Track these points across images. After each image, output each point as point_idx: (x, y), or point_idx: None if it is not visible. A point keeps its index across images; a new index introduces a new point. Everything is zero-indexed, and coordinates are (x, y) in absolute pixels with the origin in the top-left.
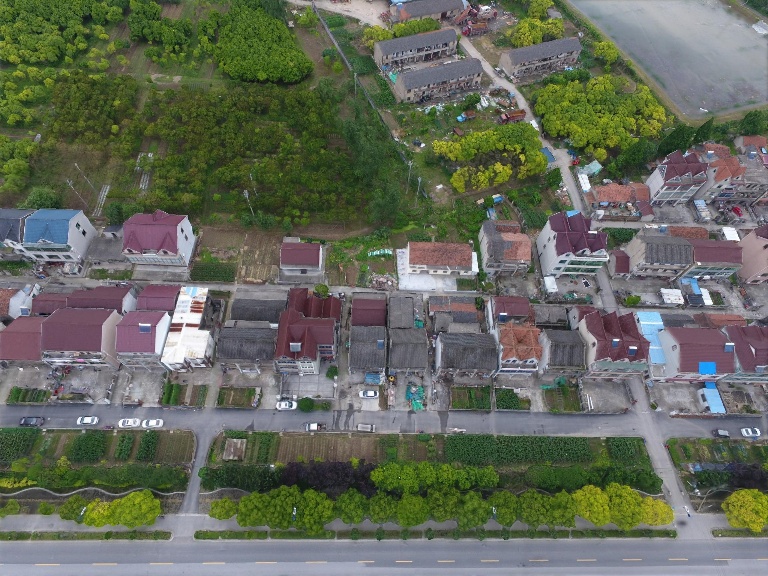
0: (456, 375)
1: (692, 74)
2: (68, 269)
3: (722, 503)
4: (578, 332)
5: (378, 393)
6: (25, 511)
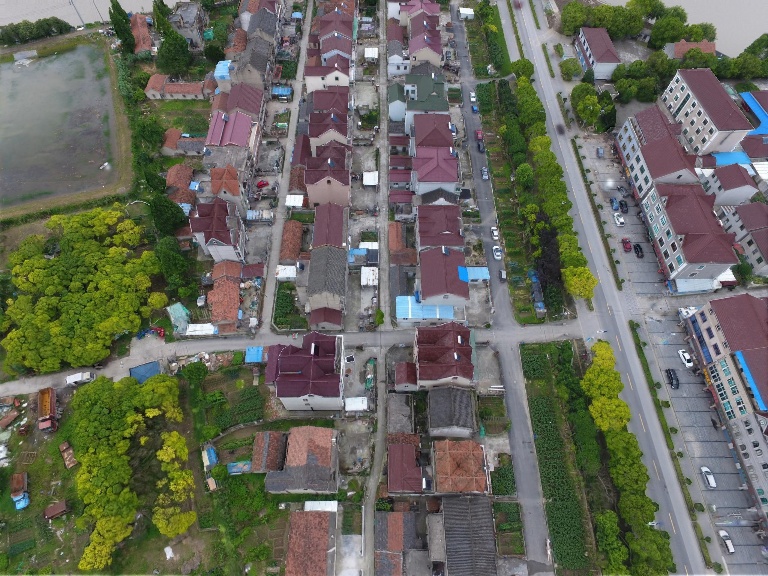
0: None
1: (37, 158)
2: None
3: (576, 298)
4: (432, 389)
5: None
6: None
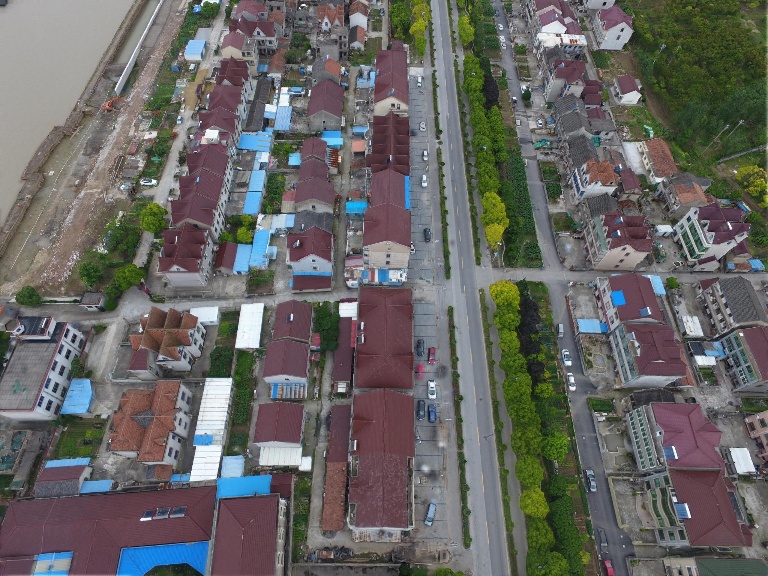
0: (564, 166)
1: None
2: (580, 7)
3: None
4: None
5: (541, 125)
6: None
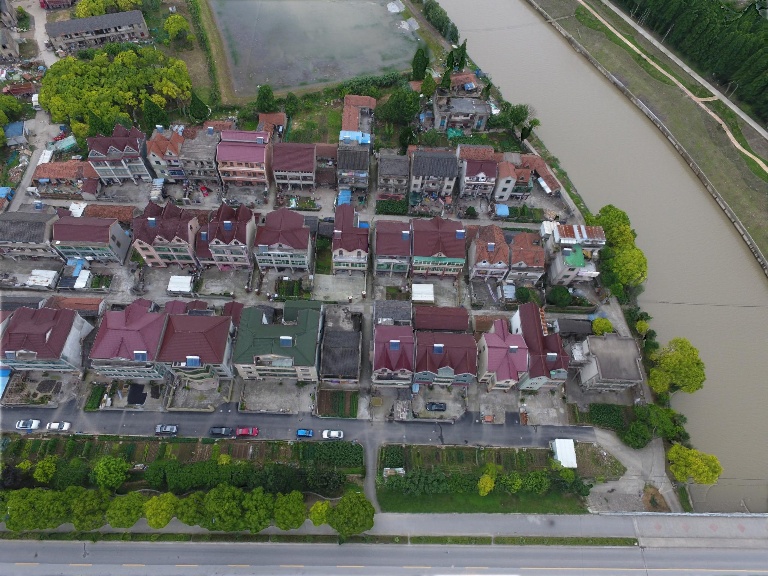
0: None
1: (278, 51)
2: None
3: None
4: None
5: None
6: None
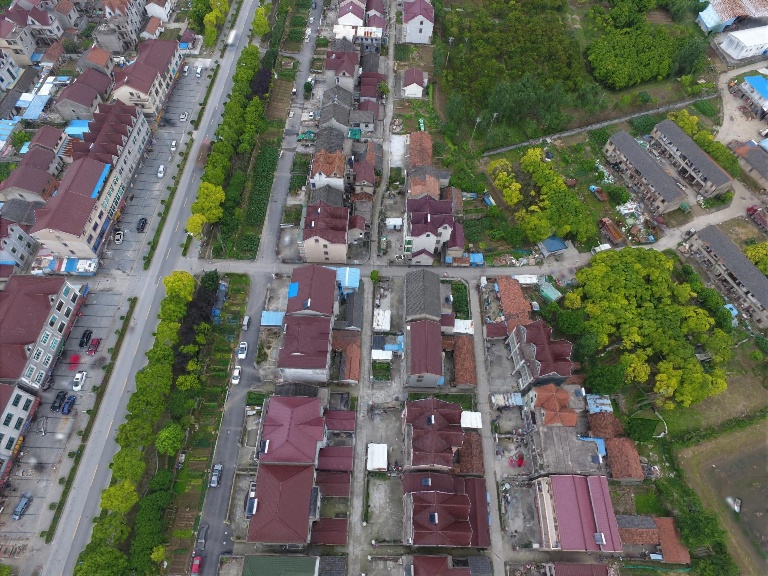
0: None
1: None
2: (400, 1)
3: None
4: None
5: (311, 117)
6: (271, 7)
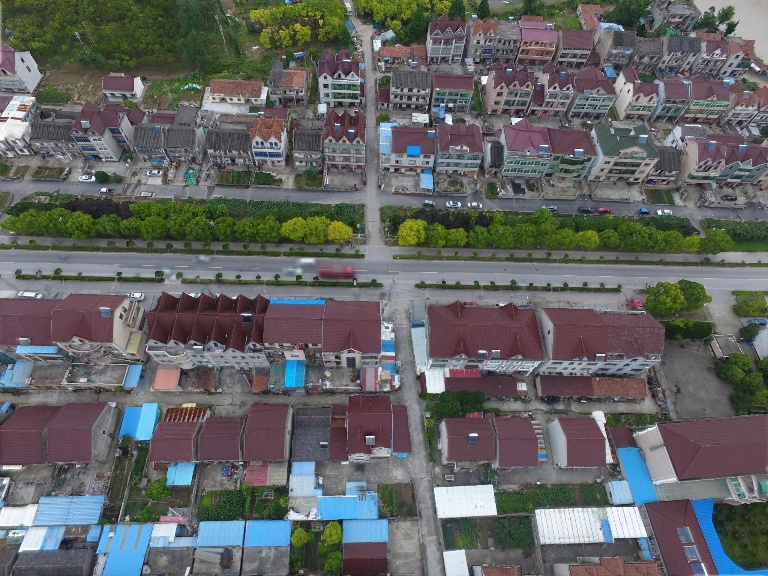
0: (228, 164)
1: None
2: None
3: None
4: None
5: (161, 172)
6: None
